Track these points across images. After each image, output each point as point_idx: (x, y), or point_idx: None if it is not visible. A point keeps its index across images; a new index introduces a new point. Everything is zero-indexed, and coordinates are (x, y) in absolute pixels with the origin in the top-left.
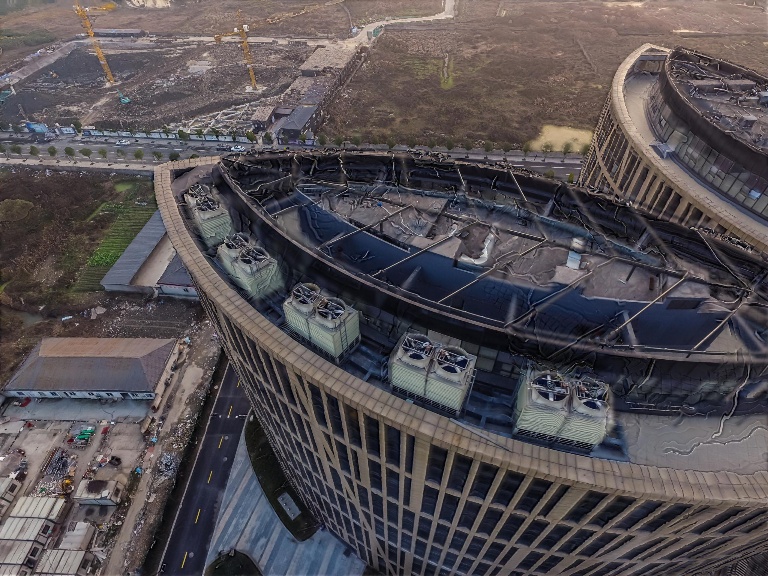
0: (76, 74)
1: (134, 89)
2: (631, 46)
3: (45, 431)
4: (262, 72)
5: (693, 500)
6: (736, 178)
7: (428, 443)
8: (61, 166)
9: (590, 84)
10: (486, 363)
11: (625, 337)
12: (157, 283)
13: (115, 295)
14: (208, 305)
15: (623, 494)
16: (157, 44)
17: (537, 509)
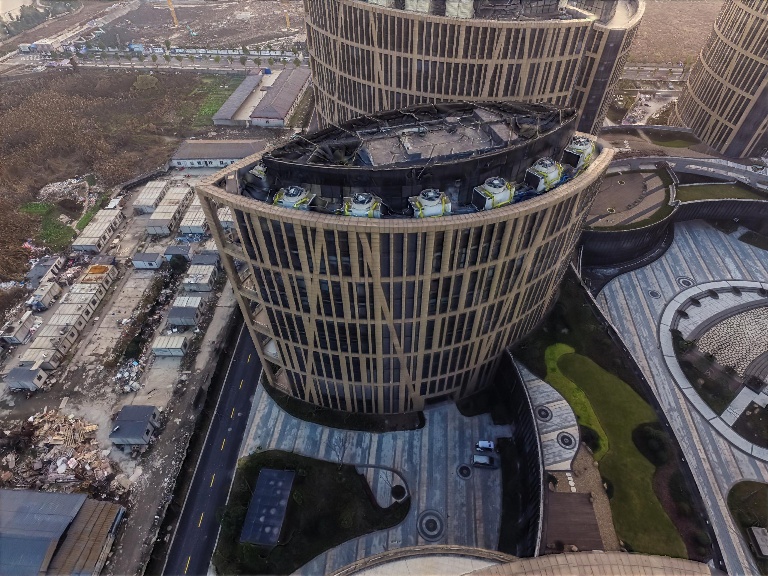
0: (146, 22)
1: (197, 28)
2: None
3: (198, 178)
4: (293, 19)
5: (494, 23)
6: None
7: (418, 21)
8: (161, 68)
9: None
10: None
11: (485, 2)
12: (250, 117)
13: (221, 127)
14: (333, 13)
15: (475, 25)
16: (206, 1)
17: (454, 52)
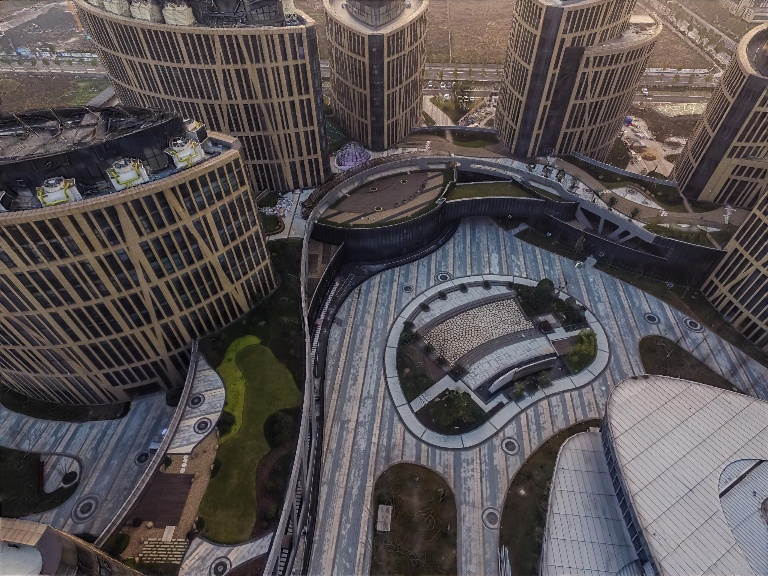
0: (54, 26)
1: None
2: (486, 4)
3: None
4: None
5: (205, 30)
6: (352, 5)
7: (140, 28)
8: (40, 72)
9: (439, 26)
10: (154, 1)
11: (215, 10)
12: None
13: None
14: None
15: (188, 32)
16: None
17: (180, 57)
